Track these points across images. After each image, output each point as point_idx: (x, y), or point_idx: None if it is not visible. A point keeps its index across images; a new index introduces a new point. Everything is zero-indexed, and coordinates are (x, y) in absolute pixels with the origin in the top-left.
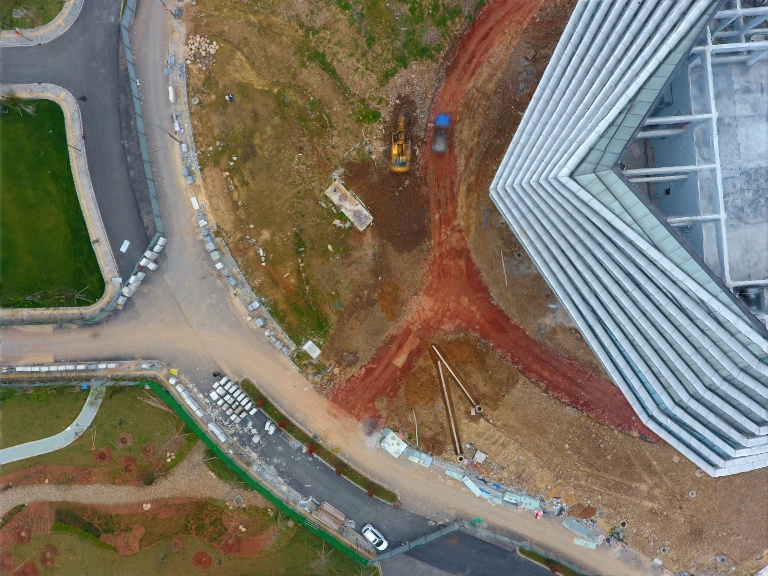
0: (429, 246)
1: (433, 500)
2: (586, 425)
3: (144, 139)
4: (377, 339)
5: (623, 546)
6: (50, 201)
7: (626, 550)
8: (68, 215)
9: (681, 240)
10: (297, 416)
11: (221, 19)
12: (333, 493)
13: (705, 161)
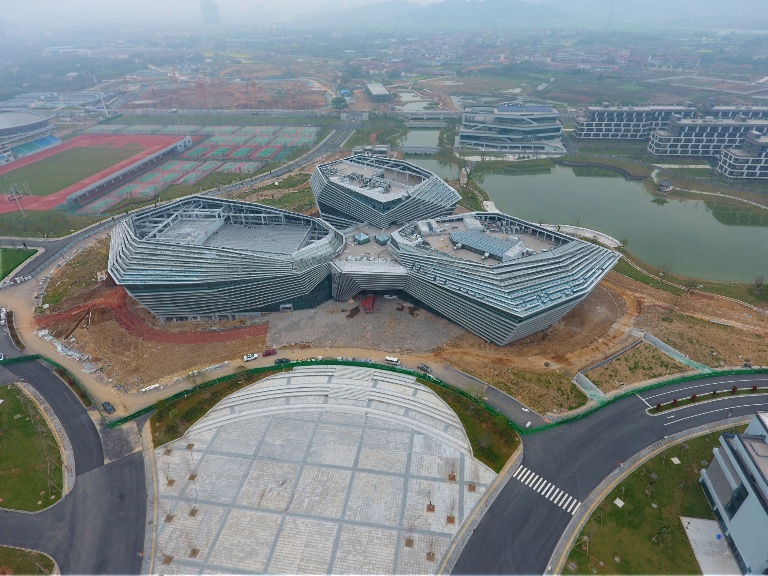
0: (118, 287)
1: (38, 351)
2: (124, 333)
3: (54, 258)
4: (73, 306)
5: (101, 373)
6: (7, 267)
7: (101, 375)
8: (8, 270)
9: (133, 224)
10: (17, 322)
11: (108, 241)
12: (1, 345)
13: (170, 231)
